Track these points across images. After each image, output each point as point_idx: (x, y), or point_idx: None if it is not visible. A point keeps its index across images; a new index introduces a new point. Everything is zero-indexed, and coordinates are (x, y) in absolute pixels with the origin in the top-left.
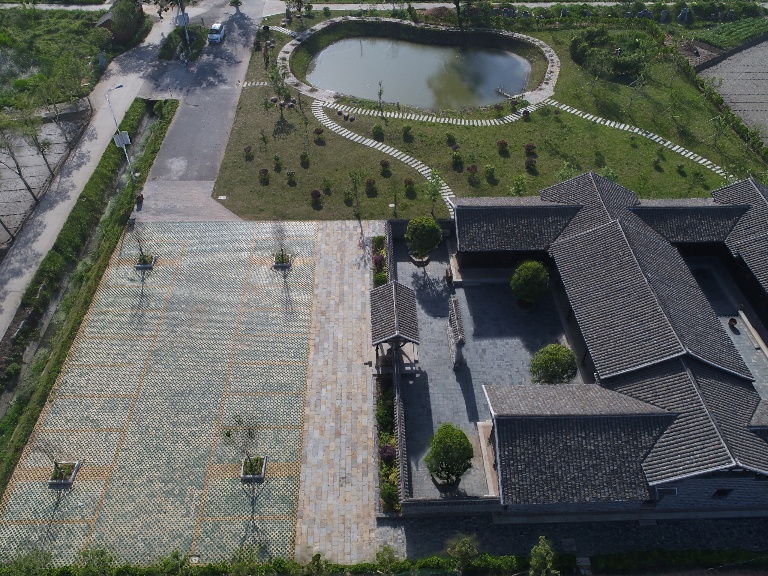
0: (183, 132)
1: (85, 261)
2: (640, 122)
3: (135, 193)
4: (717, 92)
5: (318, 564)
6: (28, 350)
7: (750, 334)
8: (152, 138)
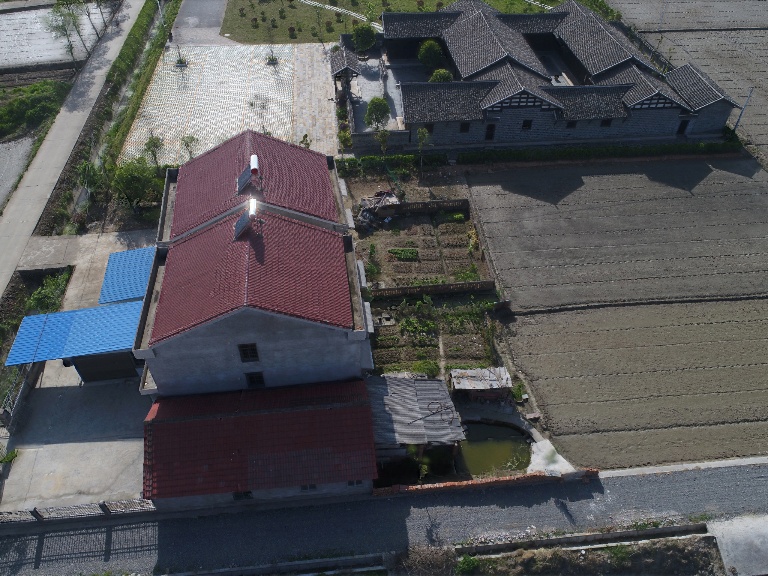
0: (193, 4)
1: (140, 66)
2: None
3: (166, 33)
4: None
5: (306, 143)
6: (114, 105)
7: (566, 82)
8: (171, 8)
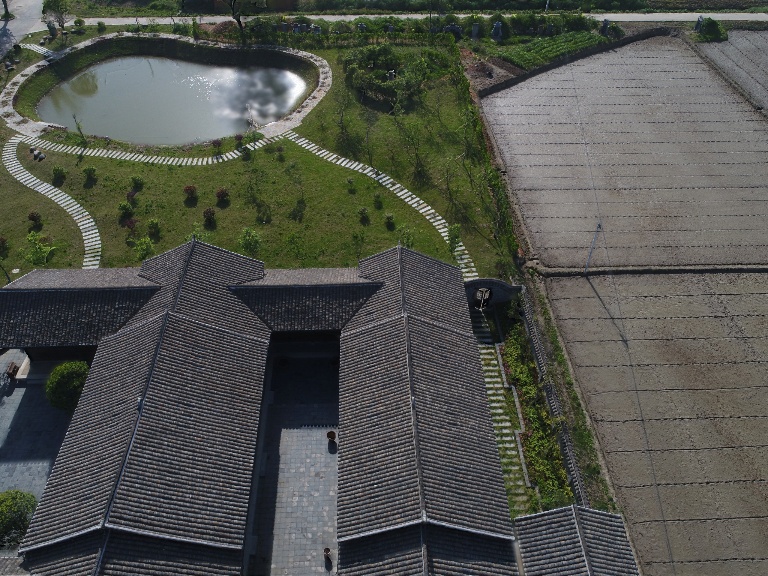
0: None
1: None
2: (377, 160)
3: None
4: (492, 121)
5: None
6: None
7: None
8: None
